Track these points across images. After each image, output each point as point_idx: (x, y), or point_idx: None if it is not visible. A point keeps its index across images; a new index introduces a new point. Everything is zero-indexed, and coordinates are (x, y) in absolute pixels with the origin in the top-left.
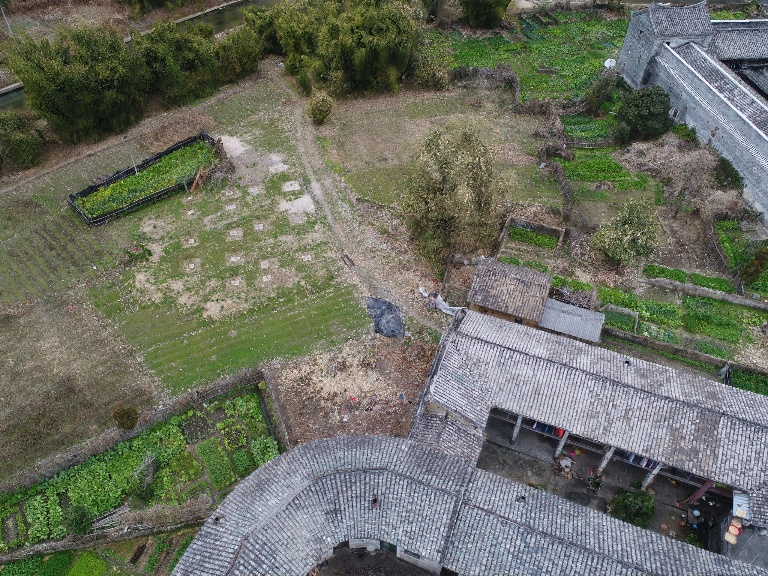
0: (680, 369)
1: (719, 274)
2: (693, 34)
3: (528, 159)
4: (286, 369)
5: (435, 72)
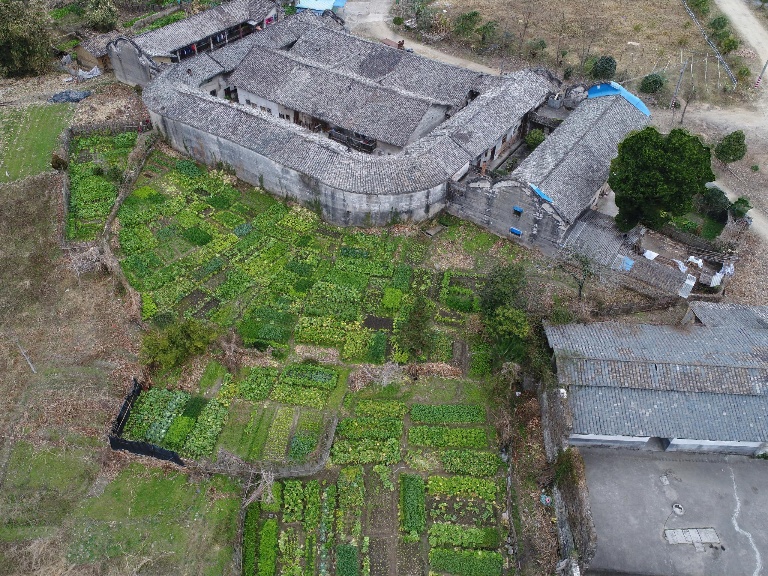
0: None
1: (148, 13)
2: None
3: None
4: None
5: None
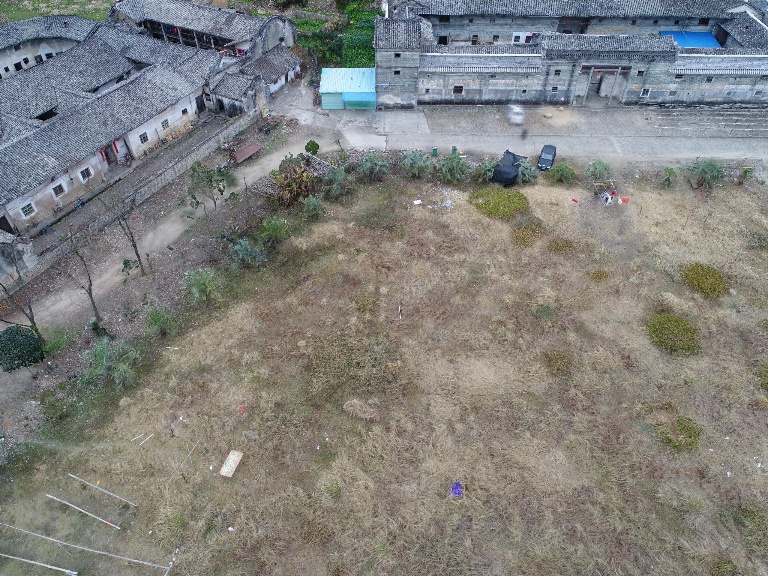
0: None
1: None
2: None
3: None
4: None
5: None
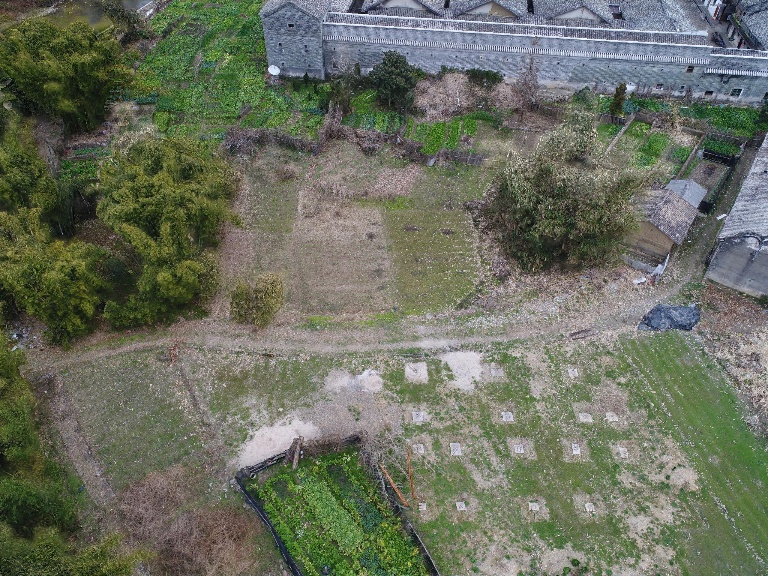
0: (699, 172)
1: None
2: (329, 4)
3: (414, 168)
4: (762, 409)
5: (231, 177)
